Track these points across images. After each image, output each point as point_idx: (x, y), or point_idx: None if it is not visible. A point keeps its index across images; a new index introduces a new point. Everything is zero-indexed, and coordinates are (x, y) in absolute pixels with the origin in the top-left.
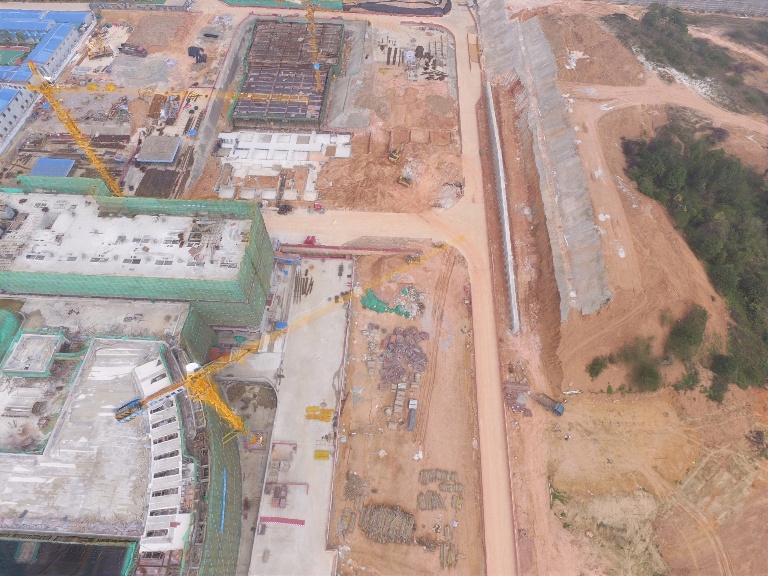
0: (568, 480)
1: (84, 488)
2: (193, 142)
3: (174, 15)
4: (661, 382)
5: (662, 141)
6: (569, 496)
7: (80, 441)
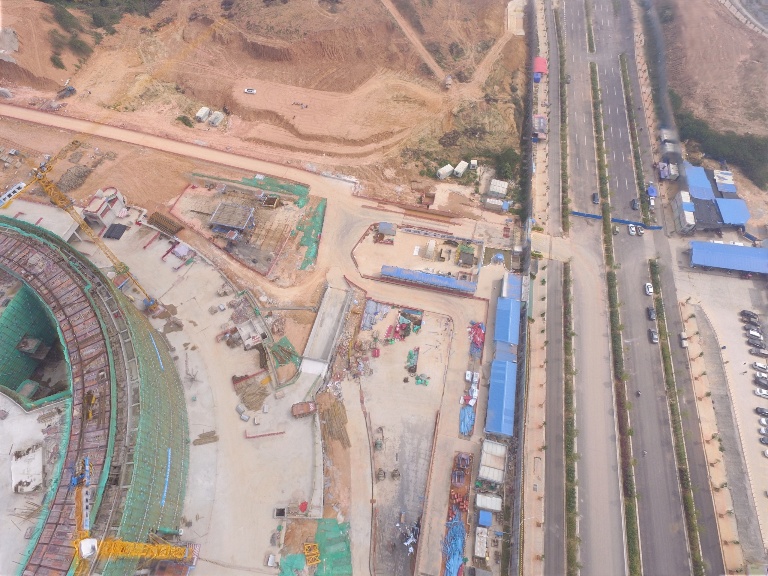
0: (110, 99)
1: None
2: None
3: None
4: (89, 46)
5: None
6: (119, 102)
7: None
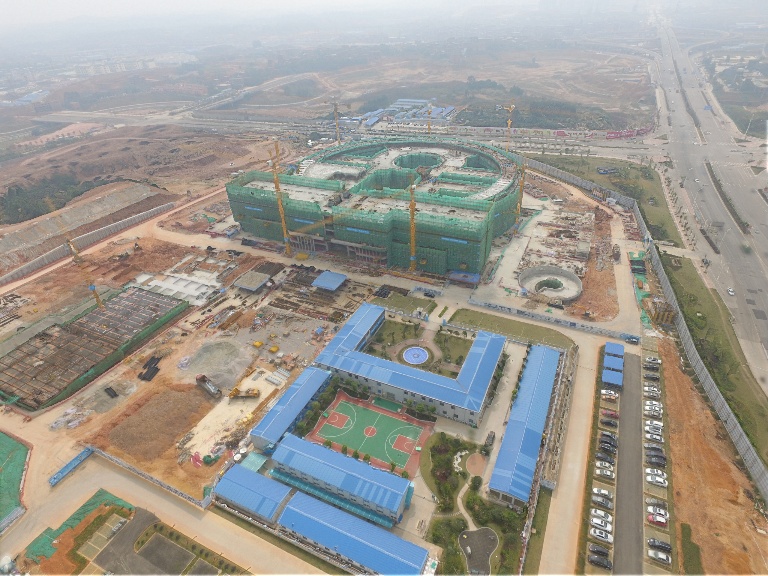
0: None
1: (326, 168)
2: (227, 291)
3: (112, 451)
4: None
5: (7, 222)
6: None
7: (325, 173)
